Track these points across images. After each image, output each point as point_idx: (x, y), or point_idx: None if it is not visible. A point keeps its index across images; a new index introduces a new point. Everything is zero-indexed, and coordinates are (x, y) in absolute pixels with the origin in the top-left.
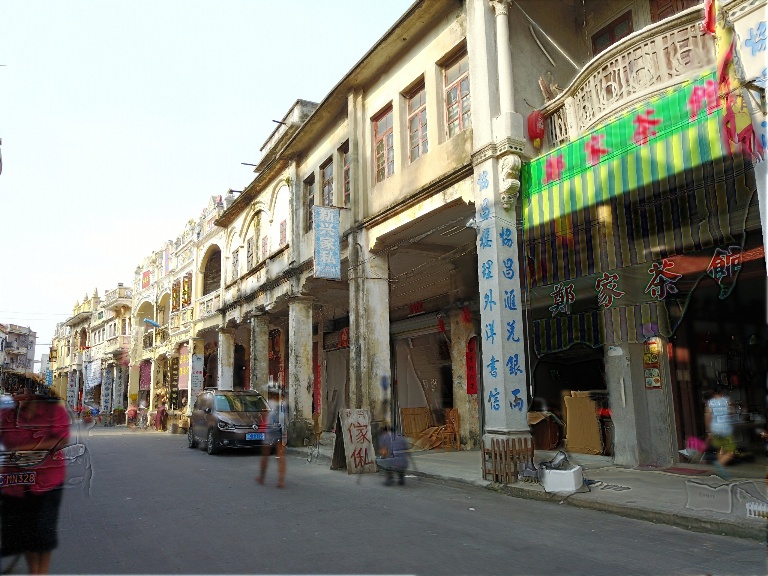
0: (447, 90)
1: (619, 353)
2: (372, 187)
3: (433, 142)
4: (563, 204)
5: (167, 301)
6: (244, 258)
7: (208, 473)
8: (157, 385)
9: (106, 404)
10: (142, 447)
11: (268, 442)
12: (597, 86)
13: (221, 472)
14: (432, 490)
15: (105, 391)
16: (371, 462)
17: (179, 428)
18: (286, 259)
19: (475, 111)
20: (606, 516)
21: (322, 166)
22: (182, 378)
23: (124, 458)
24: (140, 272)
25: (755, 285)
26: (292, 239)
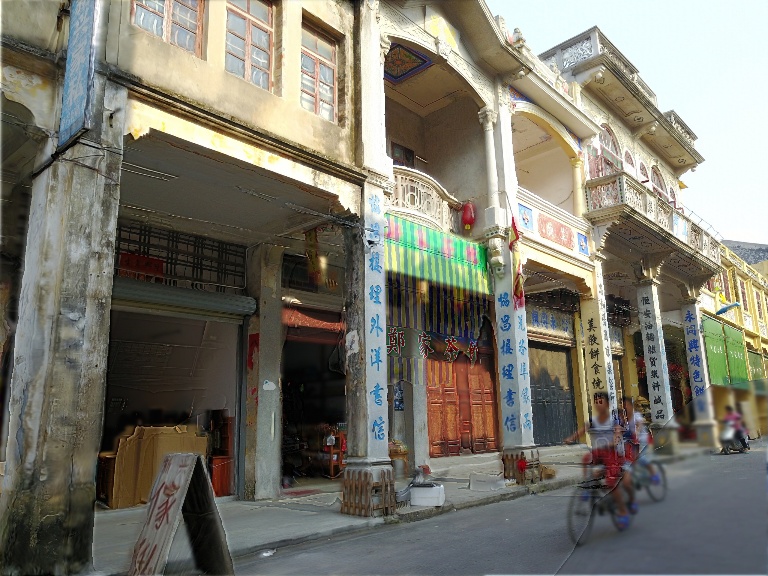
0: (302, 49)
1: (271, 388)
2: None
3: (294, 95)
4: (399, 263)
5: None
6: None
7: None
8: None
9: None
10: None
11: None
12: (403, 186)
13: None
14: (406, 535)
15: None
16: None
17: None
18: None
19: (368, 128)
20: None
21: None
22: None
23: None
24: None
25: (324, 349)
26: None
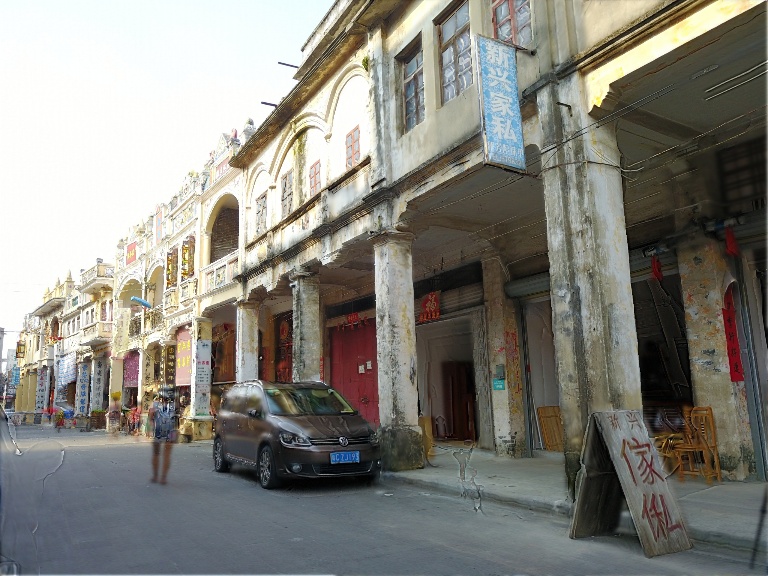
0: None
1: None
2: (585, 1)
3: None
4: None
5: (158, 278)
6: (277, 202)
7: (325, 557)
8: (147, 381)
9: (82, 405)
10: (140, 469)
11: (365, 466)
12: None
13: (351, 553)
14: None
15: (81, 390)
16: (676, 525)
17: (180, 435)
18: (362, 182)
19: None
20: None
21: (439, 18)
22: (180, 371)
23: (118, 498)
24: (124, 245)
25: None
26: (378, 146)
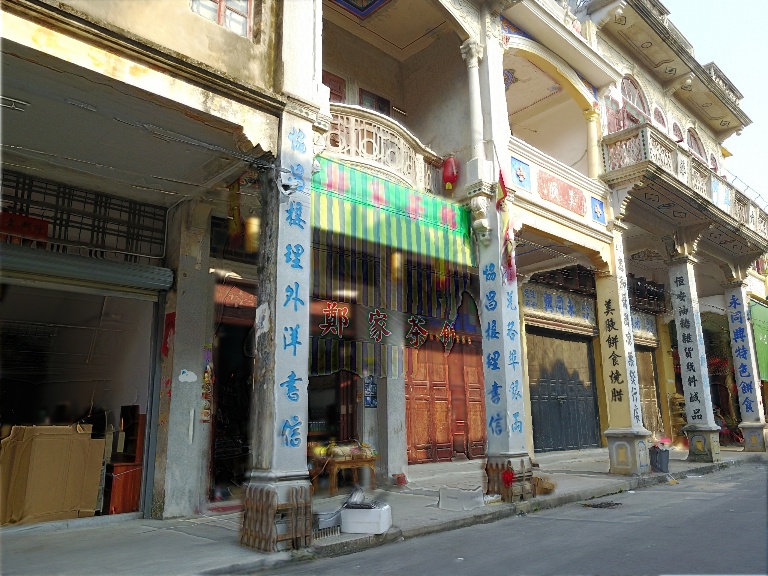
0: None
1: (190, 379)
2: None
3: None
4: (343, 222)
5: None
6: None
7: None
8: None
9: None
10: None
11: None
12: (357, 131)
13: None
14: None
15: None
16: None
17: None
18: None
19: (292, 45)
20: (452, 533)
21: None
22: None
23: None
24: None
25: None
26: None
